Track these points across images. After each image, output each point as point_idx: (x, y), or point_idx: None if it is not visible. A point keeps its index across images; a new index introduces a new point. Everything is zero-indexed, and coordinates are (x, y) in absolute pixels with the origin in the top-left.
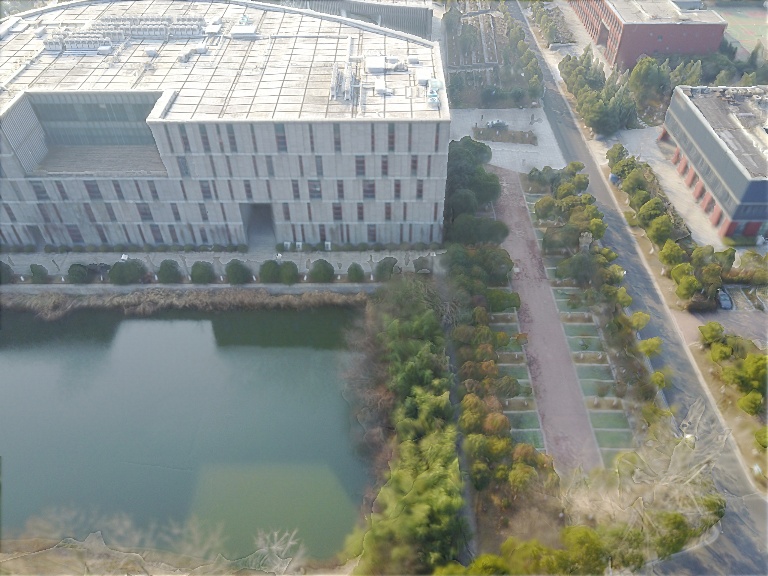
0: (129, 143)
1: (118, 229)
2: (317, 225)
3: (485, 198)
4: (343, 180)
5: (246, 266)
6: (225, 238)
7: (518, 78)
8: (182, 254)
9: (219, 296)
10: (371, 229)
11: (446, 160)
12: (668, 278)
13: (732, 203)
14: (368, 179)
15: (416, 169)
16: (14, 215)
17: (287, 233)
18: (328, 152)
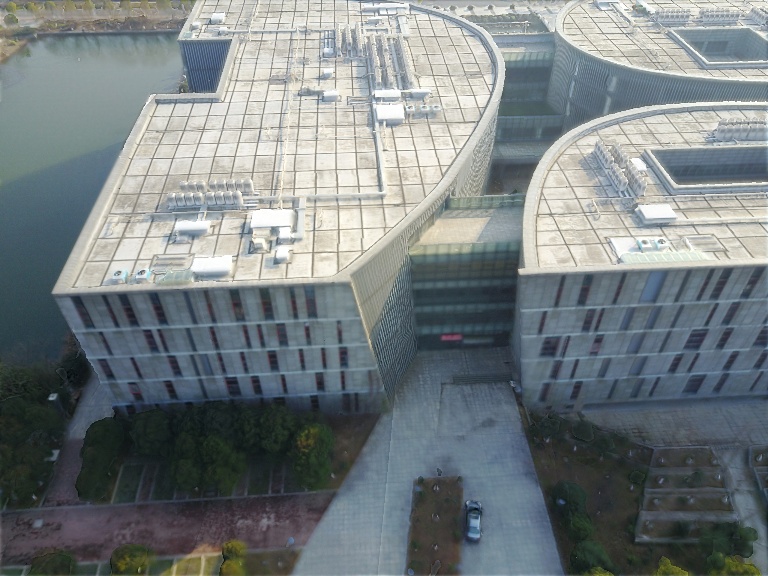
0: None
1: None
2: None
3: None
4: None
5: None
6: None
7: None
8: None
9: None
10: None
11: None
12: None
13: None
14: None
15: None
16: None
17: None
18: None
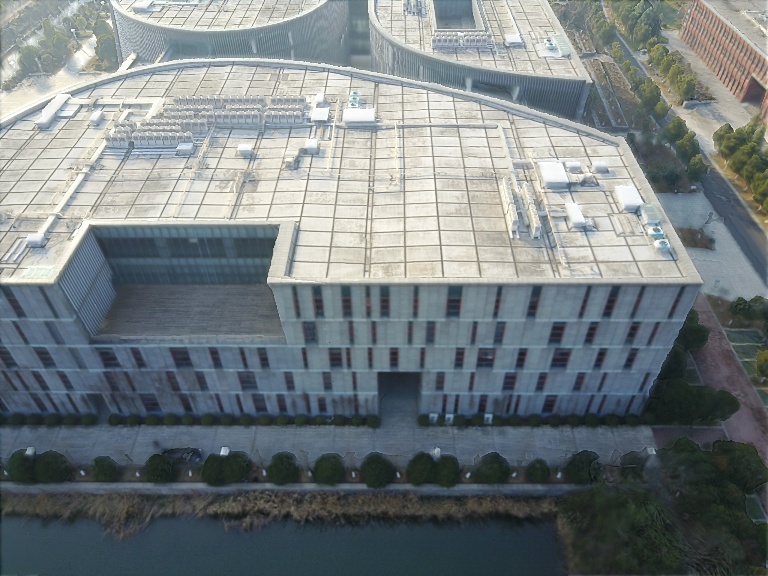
0: (223, 282)
1: (209, 398)
2: (478, 395)
3: (689, 347)
4: (528, 348)
5: (390, 462)
6: (350, 408)
7: (661, 150)
8: (292, 428)
9: (355, 507)
10: (549, 399)
11: (679, 327)
12: None
13: None
14: (563, 347)
15: (633, 337)
16: (71, 383)
17: (435, 403)
18: (516, 318)
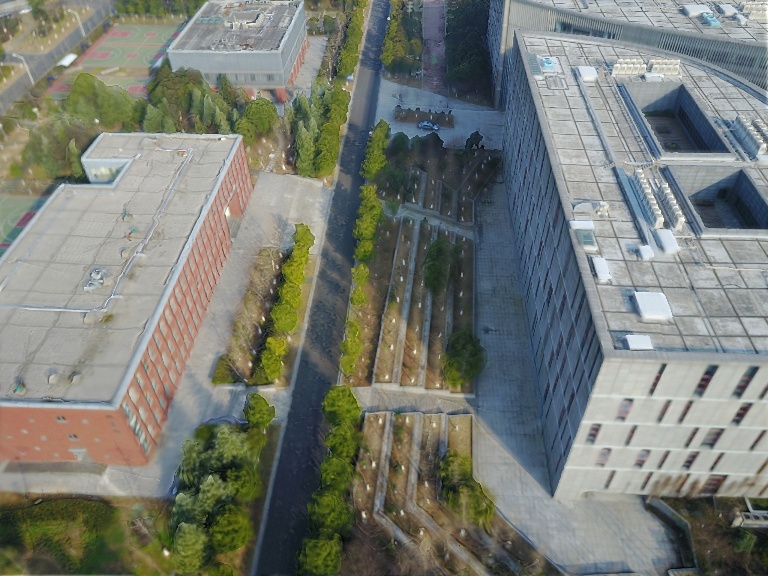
0: None
1: None
2: None
3: None
4: None
5: None
6: None
7: None
8: None
9: None
10: None
11: None
12: None
13: (305, 25)
14: None
15: None
16: None
17: None
18: None
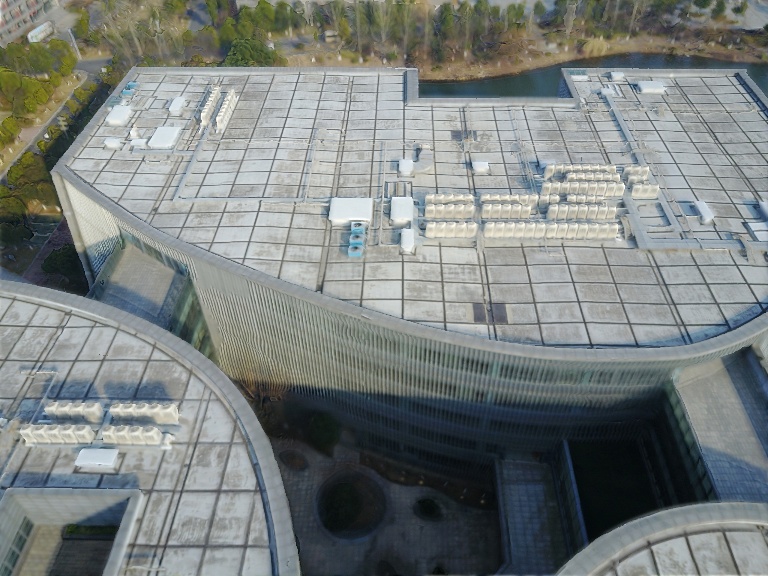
0: None
1: None
2: None
3: None
4: None
5: None
6: None
7: None
8: None
9: None
10: None
11: None
12: (4, 158)
13: None
14: None
15: None
16: None
17: None
18: None
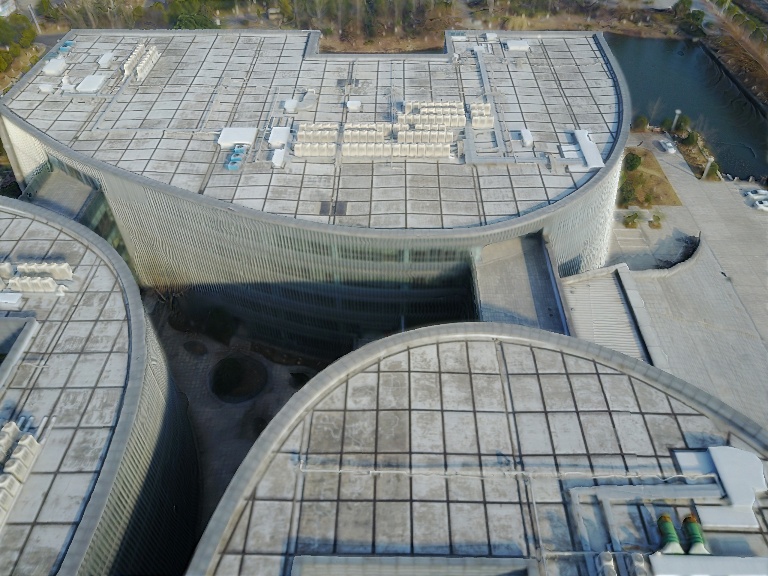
0: None
1: None
2: None
3: None
4: None
5: None
6: None
7: None
8: None
9: None
10: None
11: None
12: None
13: None
14: None
15: None
16: None
17: None
18: None
